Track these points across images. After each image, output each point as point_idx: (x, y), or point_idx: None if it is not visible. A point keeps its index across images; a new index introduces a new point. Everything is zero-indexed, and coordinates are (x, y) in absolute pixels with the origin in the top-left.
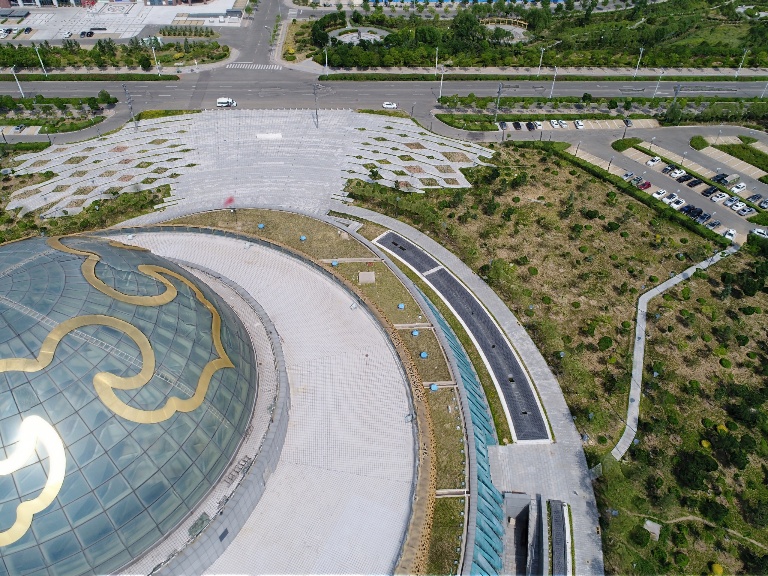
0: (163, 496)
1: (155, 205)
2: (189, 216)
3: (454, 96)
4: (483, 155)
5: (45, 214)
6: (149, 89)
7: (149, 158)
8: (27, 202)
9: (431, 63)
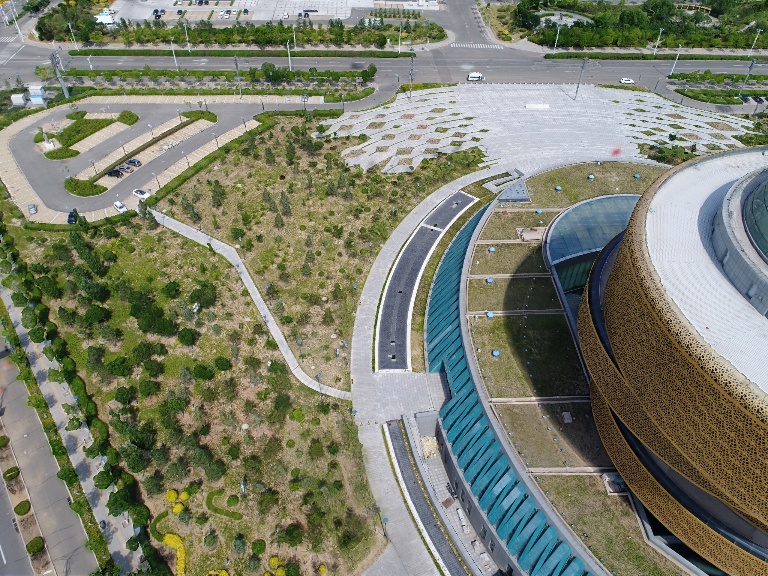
0: None
1: (478, 164)
2: (563, 167)
3: (696, 72)
4: (745, 125)
5: (385, 170)
6: (394, 65)
7: (441, 124)
8: (361, 160)
9: (645, 44)
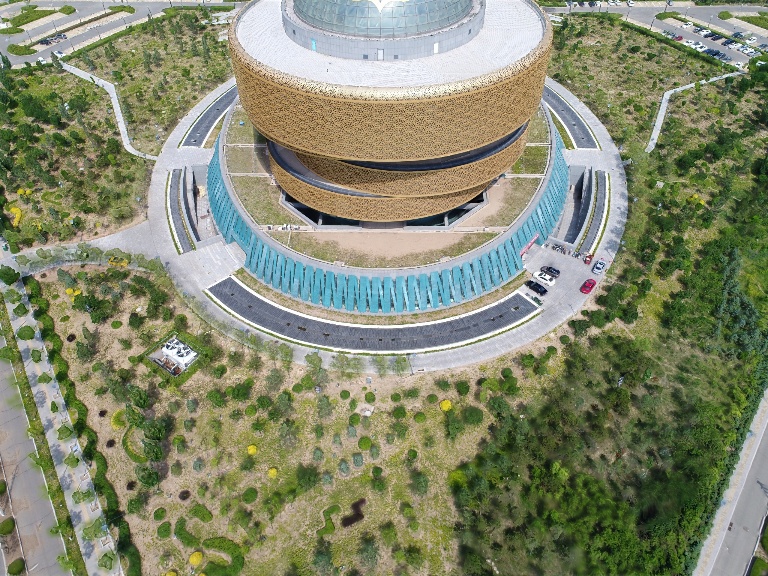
0: (451, 6)
1: None
2: None
3: None
4: (555, 20)
5: None
6: None
7: None
8: None
9: None
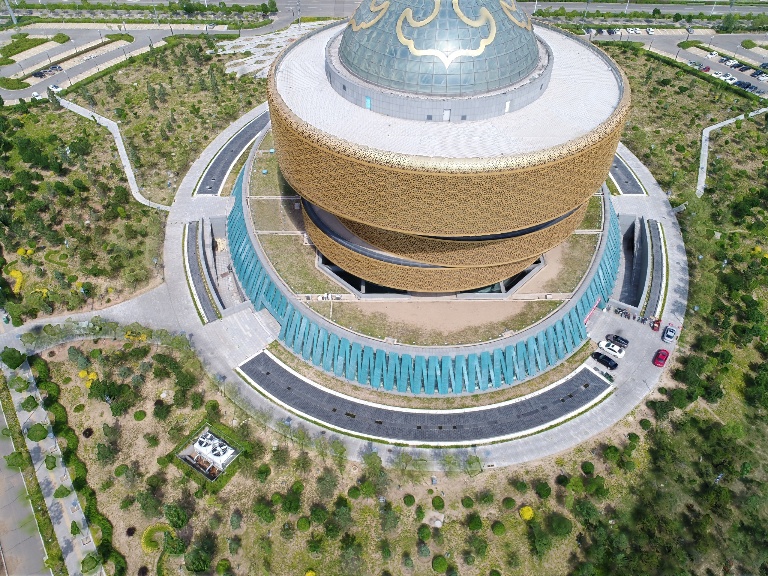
0: None
1: None
2: None
3: (549, 8)
4: None
5: (256, 76)
6: None
7: None
8: (239, 69)
9: None
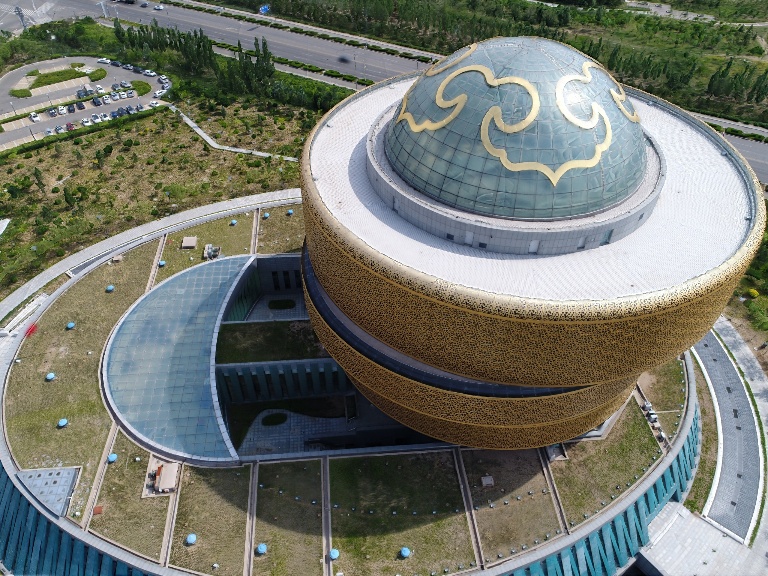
0: None
1: None
2: (5, 408)
3: None
4: None
5: None
6: None
7: None
8: None
9: None
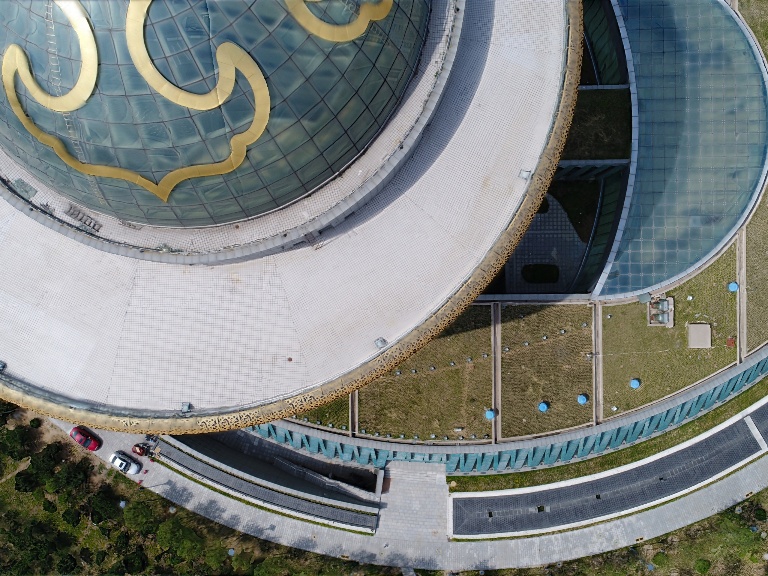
0: None
1: None
2: None
3: None
4: None
5: None
6: None
7: None
8: None
9: None
